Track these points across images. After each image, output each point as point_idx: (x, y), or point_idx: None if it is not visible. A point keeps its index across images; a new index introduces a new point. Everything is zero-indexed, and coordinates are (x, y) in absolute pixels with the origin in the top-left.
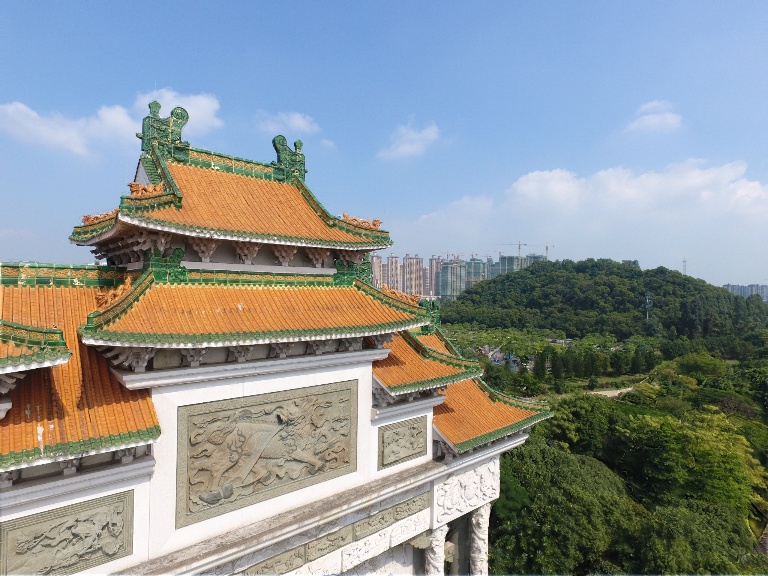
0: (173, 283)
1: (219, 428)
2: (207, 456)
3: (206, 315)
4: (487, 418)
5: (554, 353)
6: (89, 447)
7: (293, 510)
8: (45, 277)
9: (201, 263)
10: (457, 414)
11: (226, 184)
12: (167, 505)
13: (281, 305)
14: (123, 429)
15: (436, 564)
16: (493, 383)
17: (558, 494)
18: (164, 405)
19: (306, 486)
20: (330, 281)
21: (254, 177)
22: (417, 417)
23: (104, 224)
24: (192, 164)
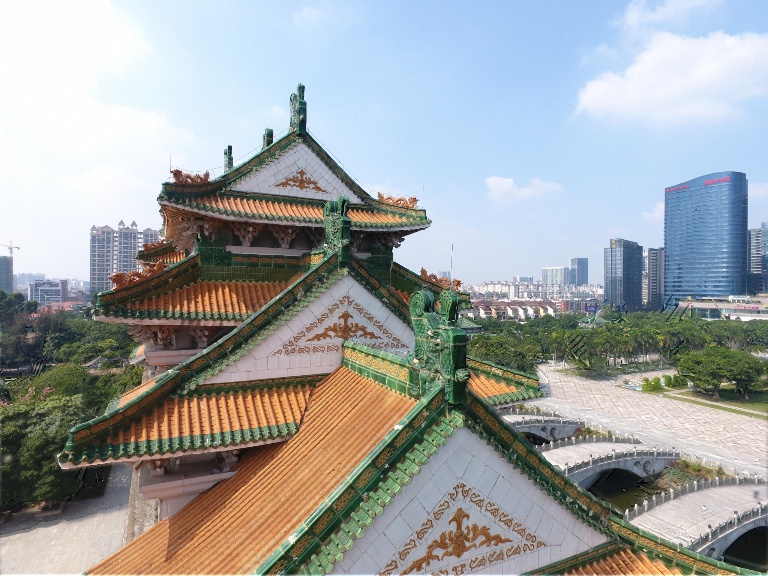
0: None
1: None
2: None
3: None
4: None
5: None
6: None
7: None
8: None
9: None
10: (158, 568)
11: None
12: None
13: None
14: None
15: None
16: None
17: None
18: None
19: None
20: None
21: None
22: None
23: None
24: None
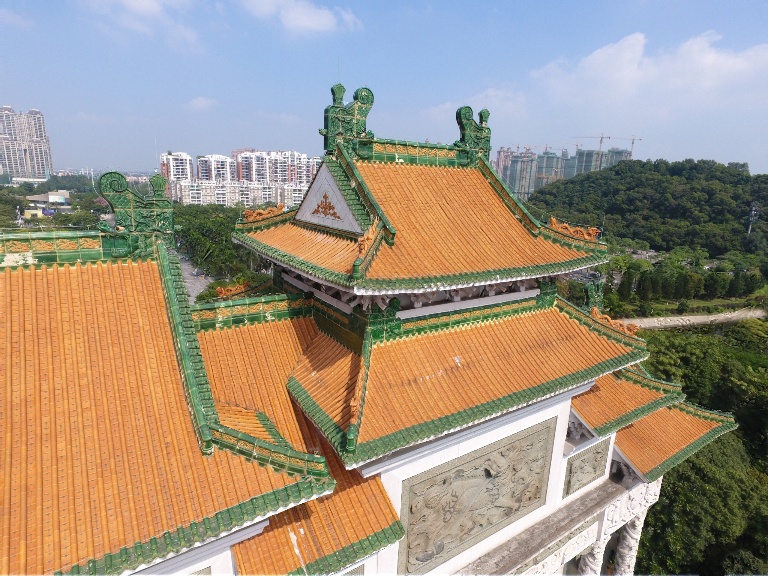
0: (389, 339)
1: (437, 494)
2: (424, 520)
3: (432, 383)
4: (667, 433)
5: (642, 272)
6: (346, 562)
7: (491, 552)
8: (240, 315)
9: (414, 310)
10: (636, 429)
11: (416, 186)
12: (391, 572)
13: (495, 350)
14: (368, 528)
15: (594, 567)
16: (575, 303)
17: (688, 469)
18: (391, 482)
19: (502, 527)
20: (533, 305)
21: (438, 166)
22: (602, 440)
23: (269, 221)
24: (376, 160)
